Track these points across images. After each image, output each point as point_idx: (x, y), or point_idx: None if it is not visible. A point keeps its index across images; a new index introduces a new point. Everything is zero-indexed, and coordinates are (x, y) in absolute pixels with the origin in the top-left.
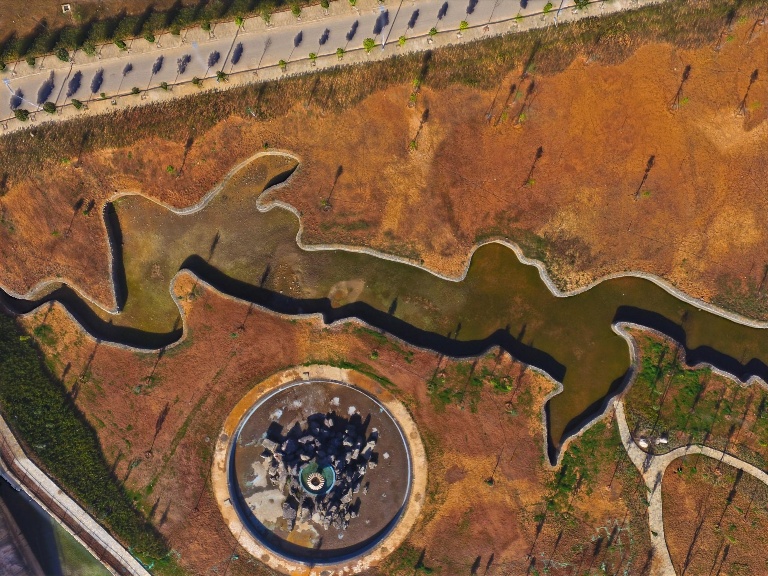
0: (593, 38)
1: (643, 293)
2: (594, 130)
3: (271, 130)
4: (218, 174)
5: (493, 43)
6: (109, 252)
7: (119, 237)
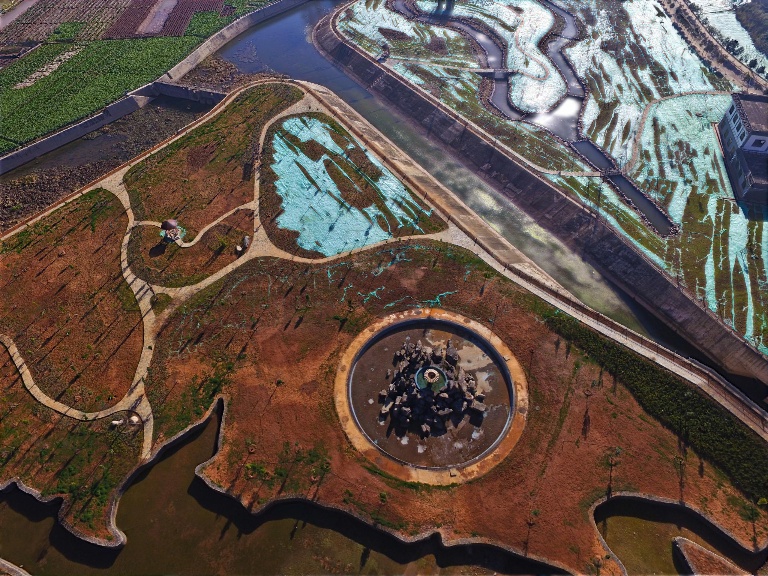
0: None
1: None
2: None
3: None
4: None
5: None
6: None
7: None
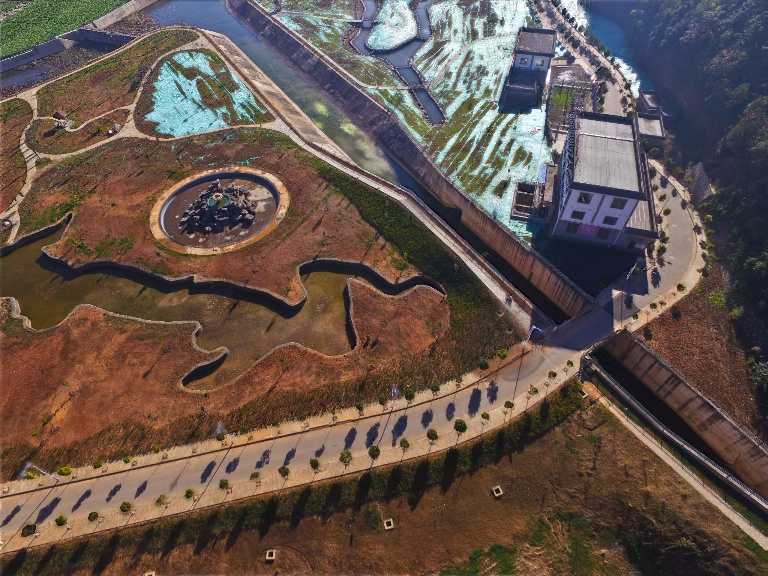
0: None
1: None
2: None
3: (197, 407)
4: (254, 371)
5: None
6: (352, 314)
7: (348, 329)
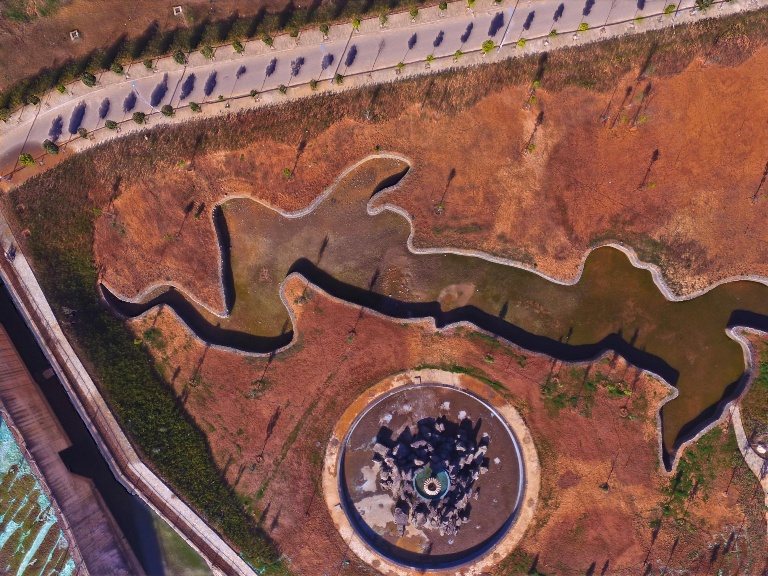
0: (711, 40)
1: (758, 297)
2: (711, 133)
3: (383, 133)
4: (329, 177)
5: (610, 45)
6: (219, 255)
7: (227, 240)
